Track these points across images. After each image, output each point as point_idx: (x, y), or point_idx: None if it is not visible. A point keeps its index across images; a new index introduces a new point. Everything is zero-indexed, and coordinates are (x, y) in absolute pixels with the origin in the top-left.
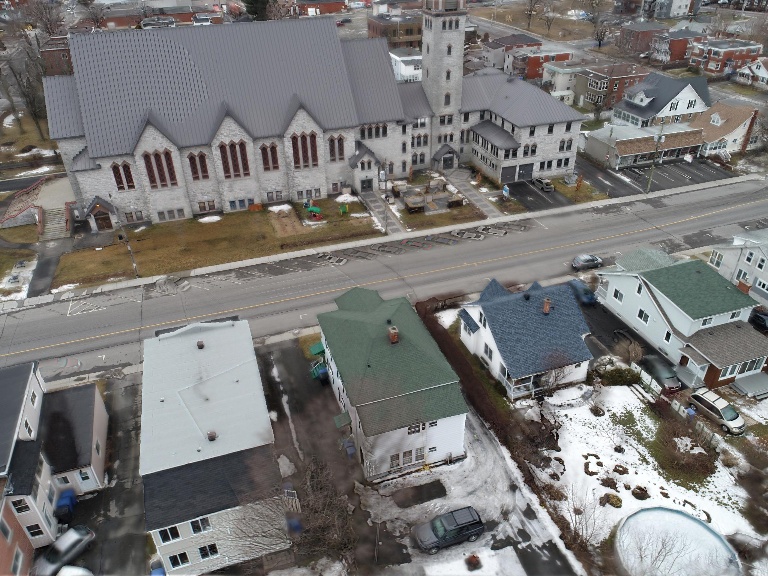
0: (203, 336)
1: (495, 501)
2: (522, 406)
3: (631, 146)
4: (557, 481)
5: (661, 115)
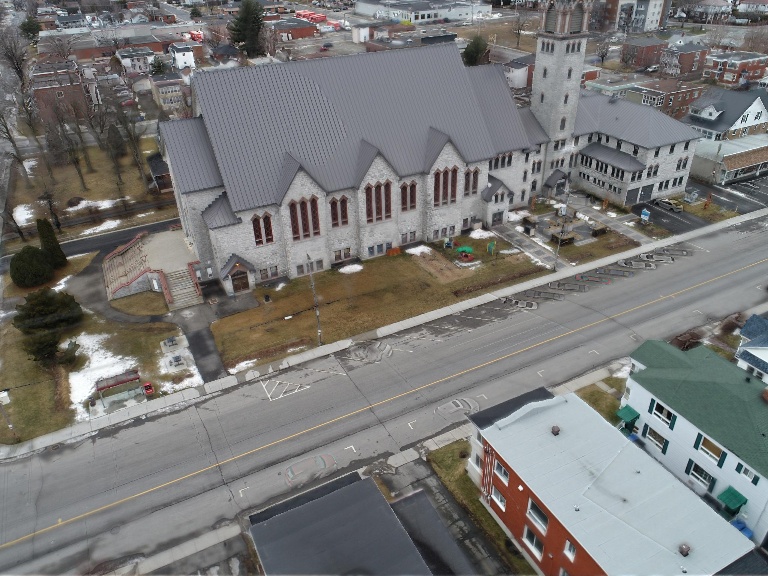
0: (544, 418)
1: None
2: None
3: (736, 161)
4: None
5: (733, 128)
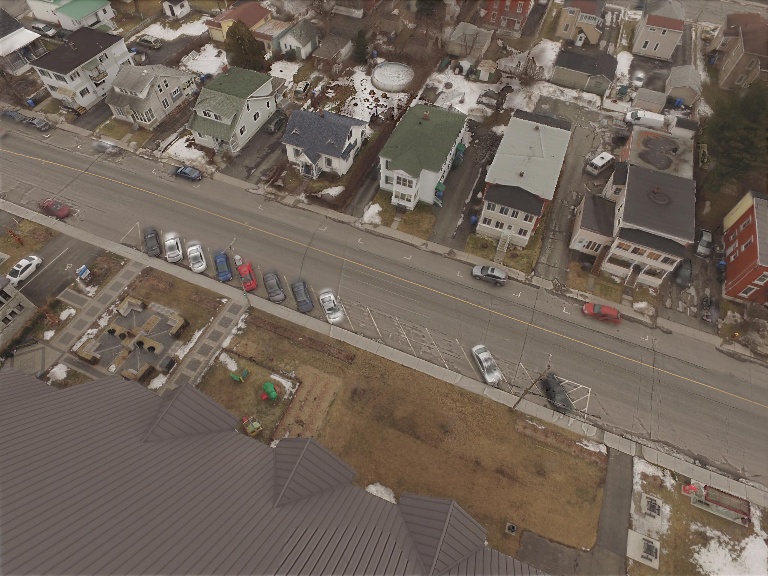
0: None
1: None
2: None
3: None
4: None
5: None
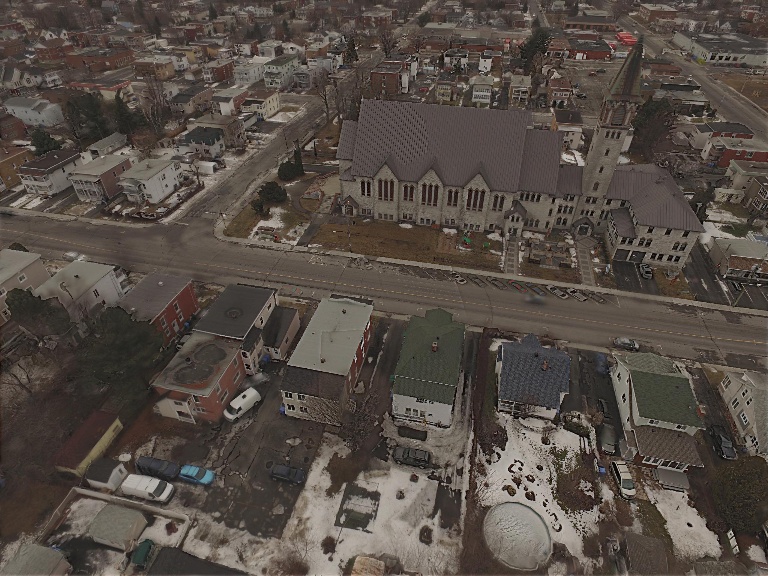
0: (348, 307)
1: (447, 457)
2: (502, 416)
3: (745, 263)
4: (488, 465)
5: None
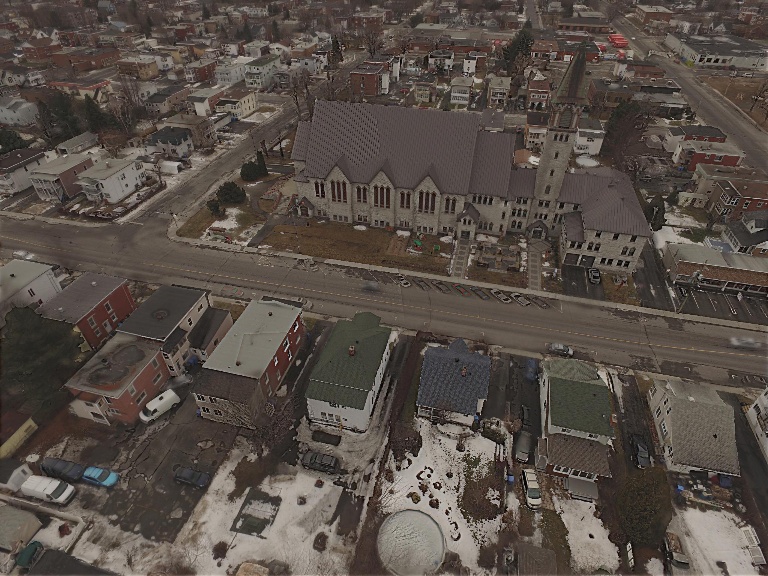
0: (276, 309)
1: (356, 462)
2: (420, 422)
3: (693, 269)
4: (397, 471)
5: (762, 247)
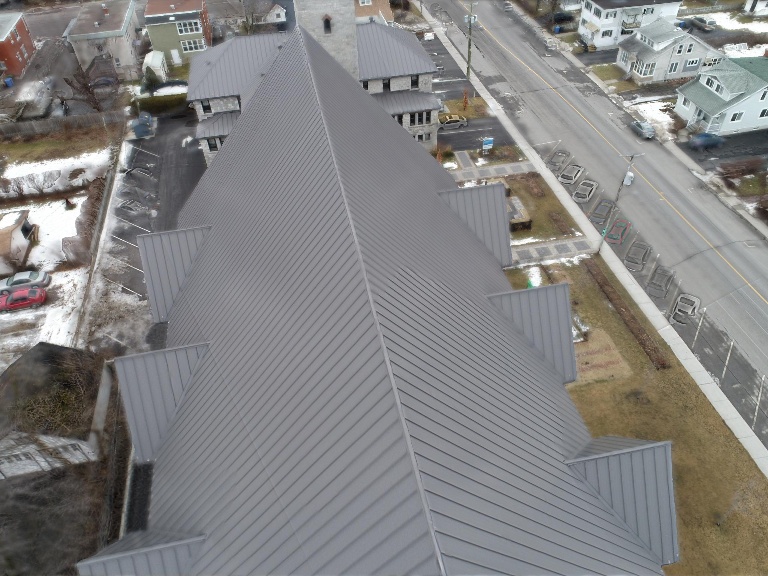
0: None
1: None
2: None
3: None
4: None
5: None
